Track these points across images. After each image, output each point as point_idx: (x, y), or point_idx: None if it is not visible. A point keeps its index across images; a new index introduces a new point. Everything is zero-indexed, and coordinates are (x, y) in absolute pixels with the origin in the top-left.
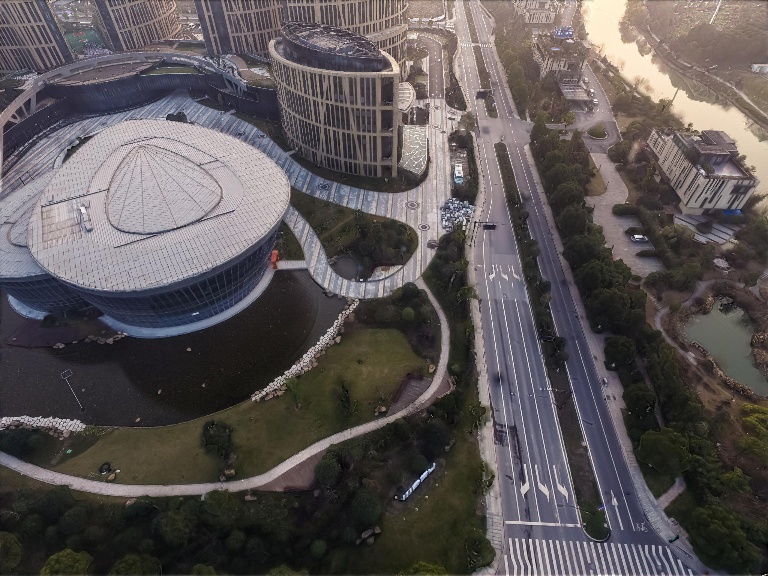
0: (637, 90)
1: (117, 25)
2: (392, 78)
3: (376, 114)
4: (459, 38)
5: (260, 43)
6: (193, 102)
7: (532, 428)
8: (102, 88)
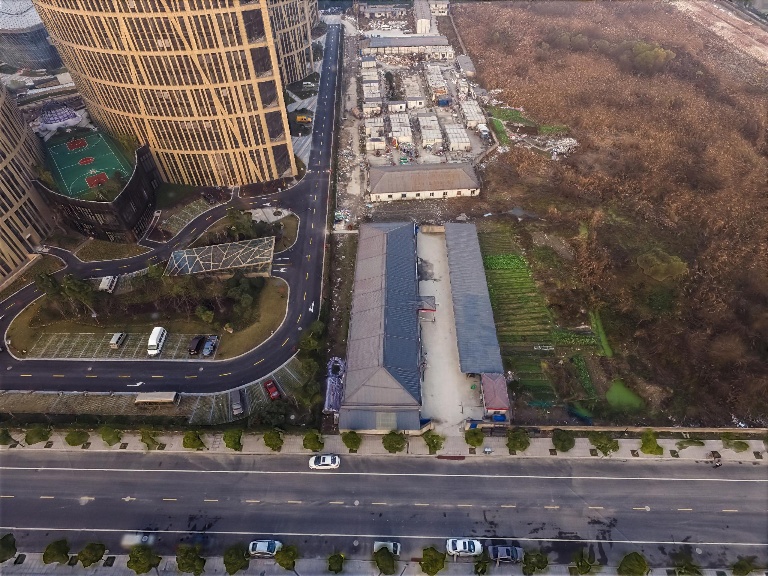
0: None
1: None
2: None
3: None
4: None
5: None
6: None
7: None
8: None
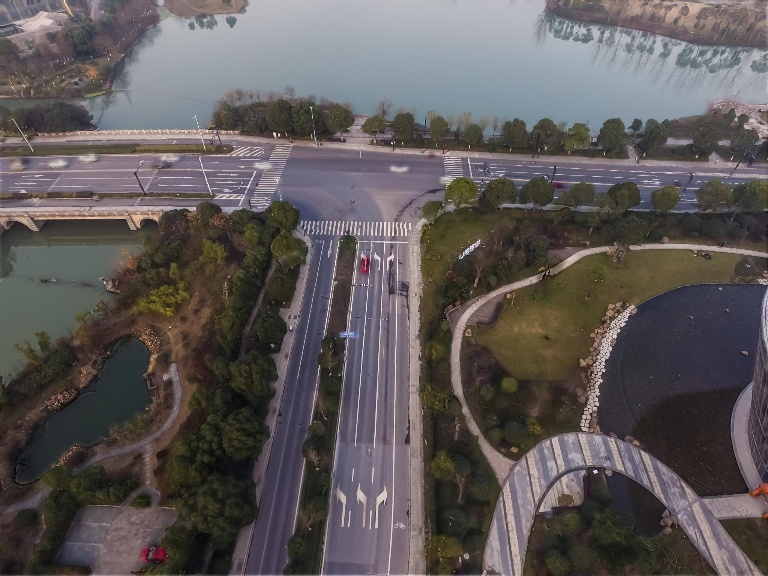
0: None
1: None
2: None
3: None
4: None
5: None
6: None
7: (375, 293)
8: None
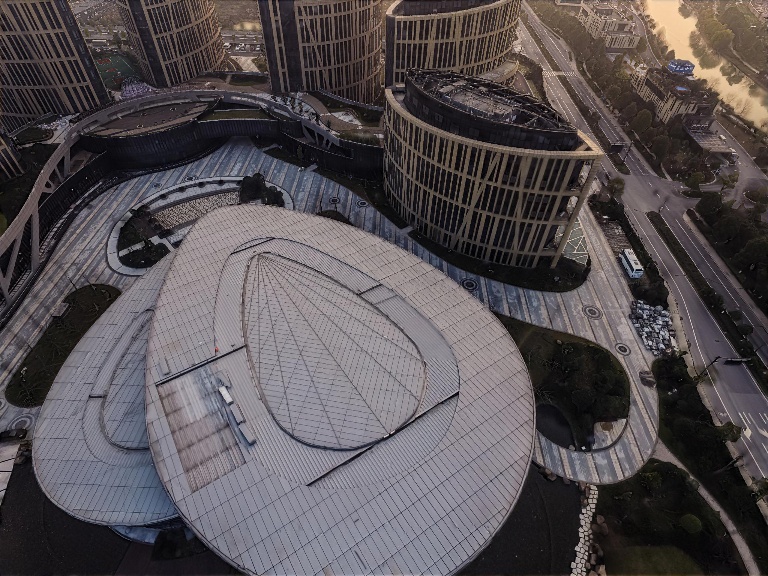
0: (767, 135)
1: (161, 56)
2: (592, 159)
3: (556, 200)
4: None
5: (336, 78)
6: (260, 153)
7: None
8: (153, 140)
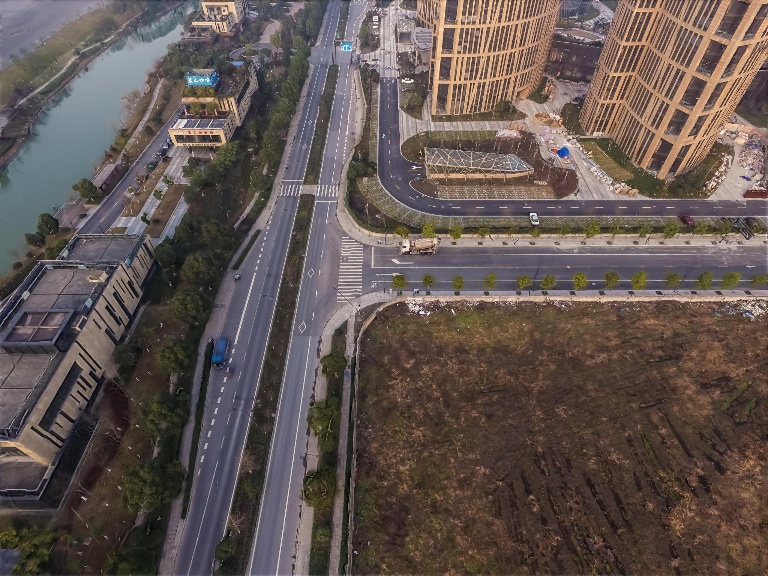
0: None
1: None
2: None
3: None
4: (338, 214)
5: None
6: None
7: None
8: None
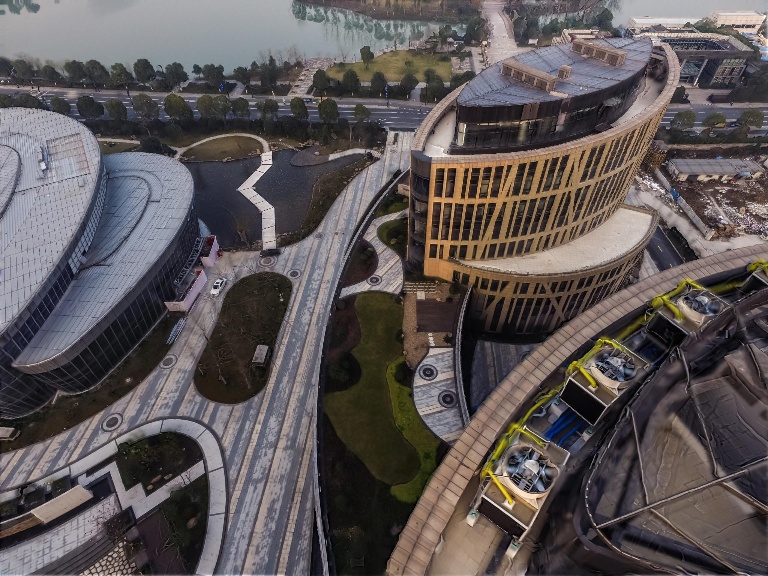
0: None
1: None
2: None
3: None
4: None
5: None
6: None
7: None
8: None
